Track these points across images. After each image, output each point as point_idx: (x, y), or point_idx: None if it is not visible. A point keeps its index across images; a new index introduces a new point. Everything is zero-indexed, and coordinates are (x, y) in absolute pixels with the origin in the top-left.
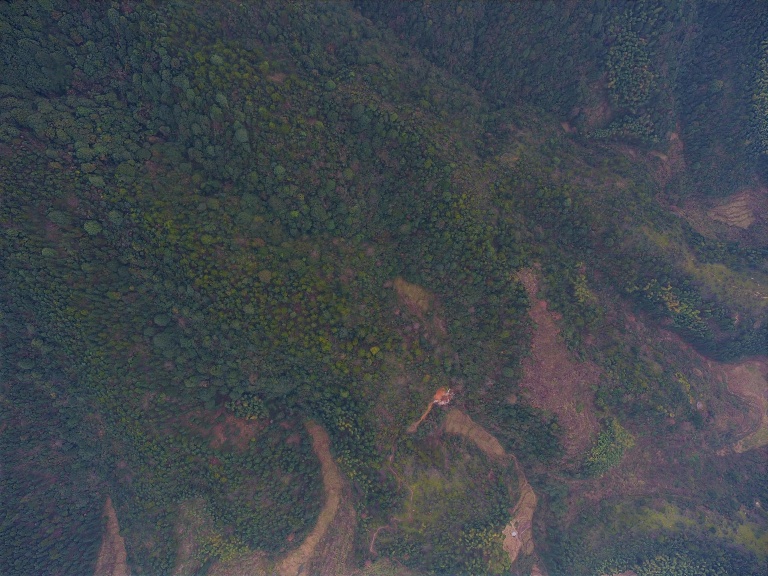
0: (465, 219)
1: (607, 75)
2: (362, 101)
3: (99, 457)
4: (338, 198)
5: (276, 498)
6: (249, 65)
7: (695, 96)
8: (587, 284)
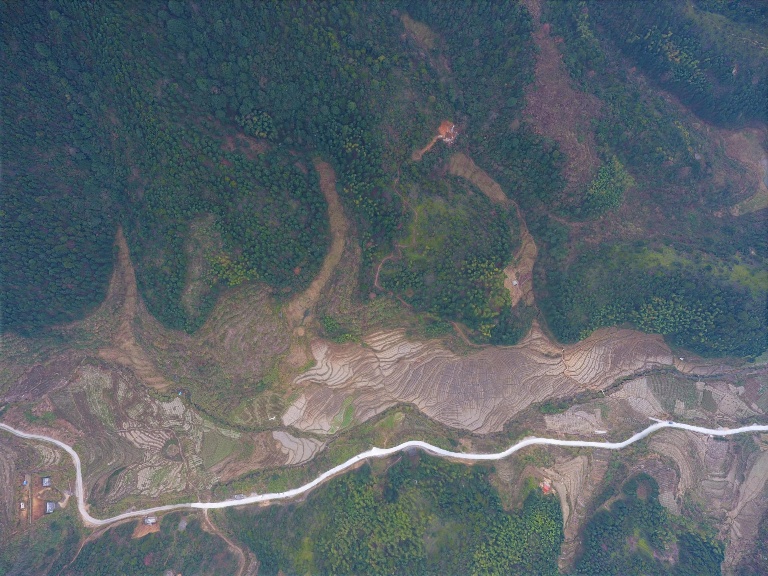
0: None
1: None
2: None
3: (111, 175)
4: None
5: (284, 219)
6: None
7: None
8: None
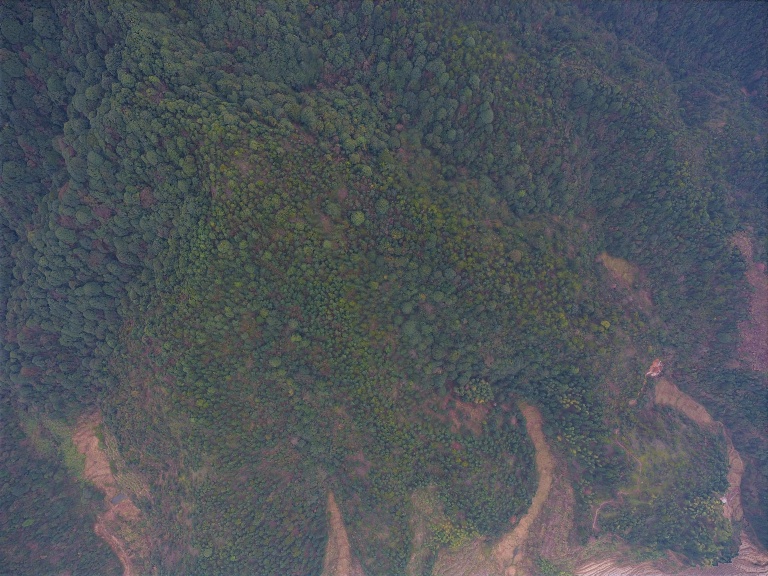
0: None
1: None
2: (585, 76)
3: (328, 452)
4: (562, 175)
5: (505, 480)
6: None
7: None
8: None
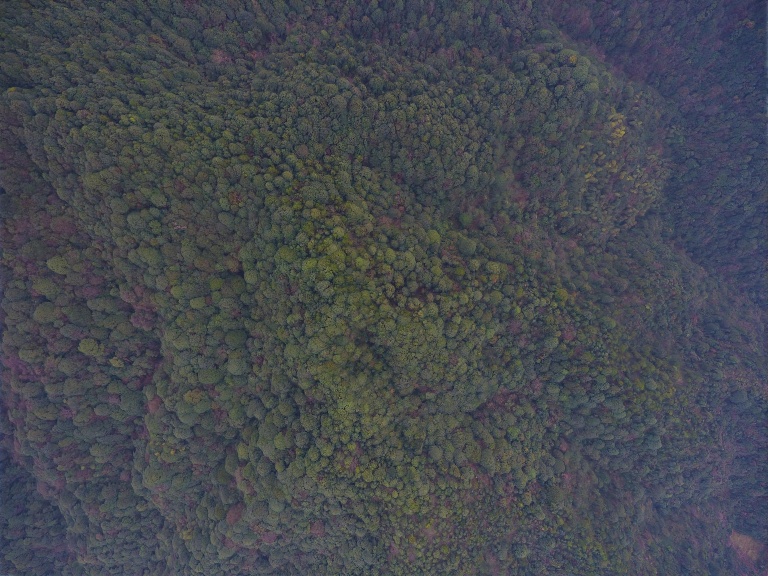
0: None
1: None
2: (745, 387)
3: None
4: (710, 478)
5: None
6: None
7: None
8: None
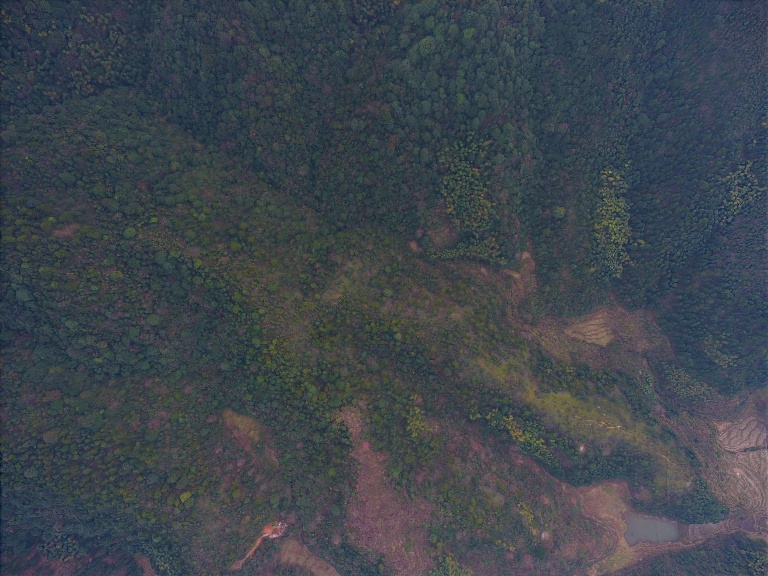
0: (278, 363)
1: (445, 202)
2: (164, 248)
3: None
4: (145, 343)
5: None
6: (28, 224)
7: (542, 219)
8: (427, 413)
